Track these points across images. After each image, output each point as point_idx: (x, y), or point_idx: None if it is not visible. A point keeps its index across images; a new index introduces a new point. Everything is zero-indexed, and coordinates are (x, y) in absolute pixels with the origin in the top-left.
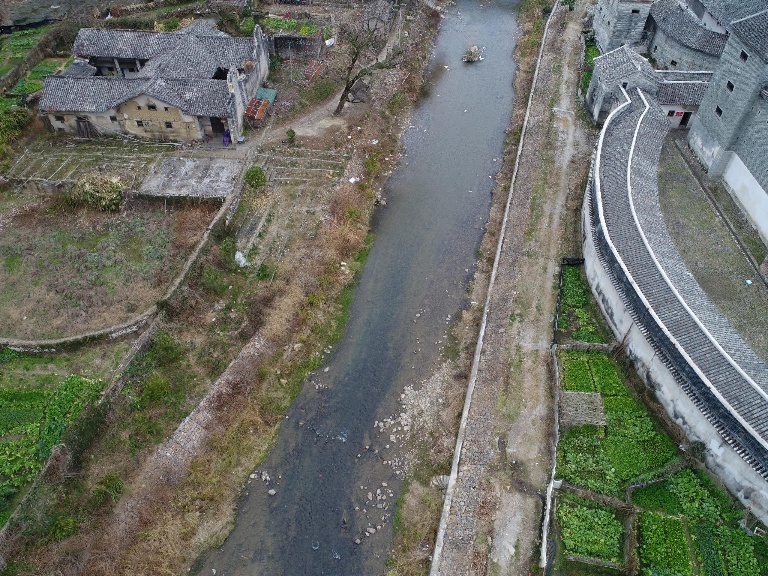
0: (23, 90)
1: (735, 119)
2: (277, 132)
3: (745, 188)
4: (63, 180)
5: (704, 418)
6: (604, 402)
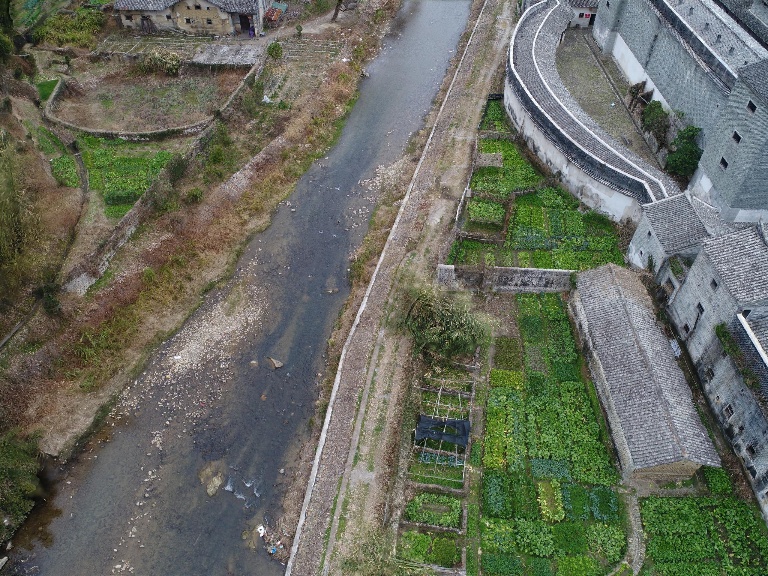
0: (96, 4)
1: (616, 6)
2: (289, 30)
3: (623, 55)
4: (138, 53)
5: (559, 152)
6: (505, 162)
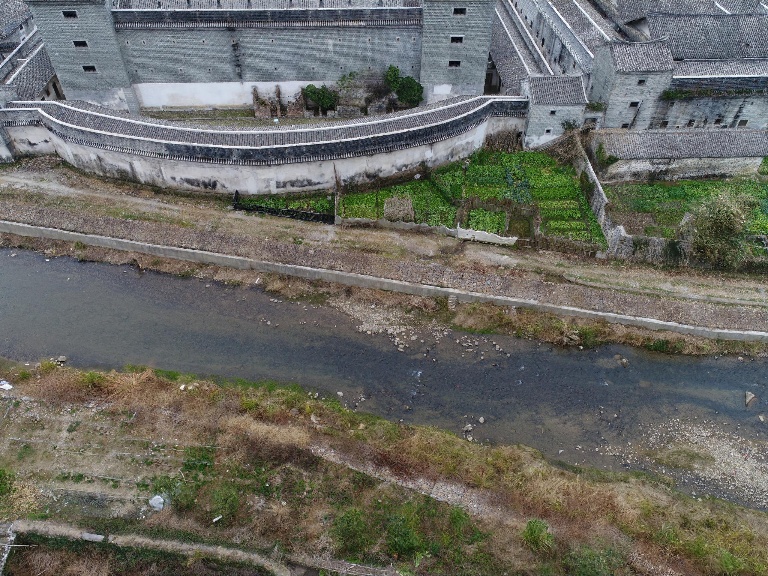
0: None
1: (116, 60)
2: None
3: (174, 95)
4: None
5: (416, 148)
6: None
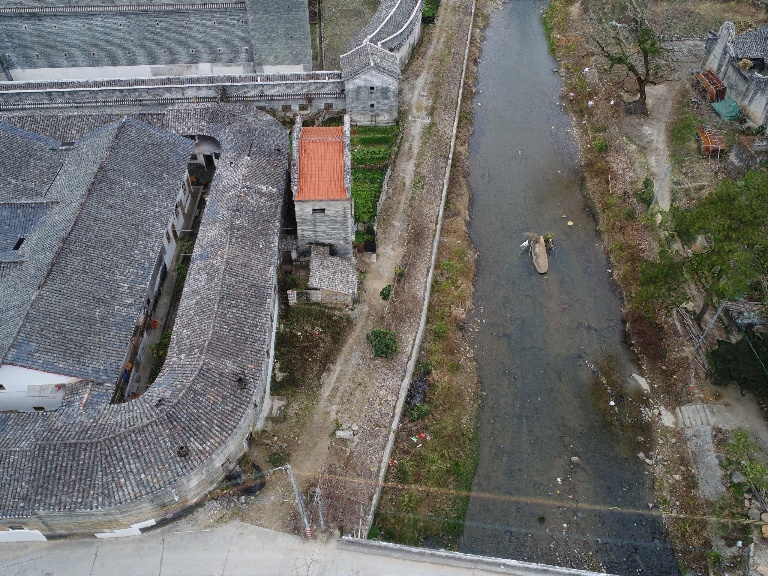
0: None
1: None
2: (676, 84)
3: None
4: None
5: None
6: None
